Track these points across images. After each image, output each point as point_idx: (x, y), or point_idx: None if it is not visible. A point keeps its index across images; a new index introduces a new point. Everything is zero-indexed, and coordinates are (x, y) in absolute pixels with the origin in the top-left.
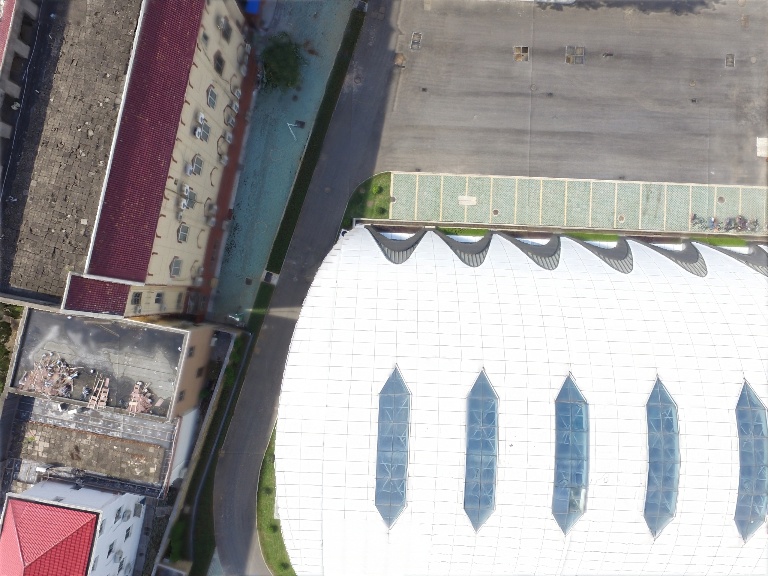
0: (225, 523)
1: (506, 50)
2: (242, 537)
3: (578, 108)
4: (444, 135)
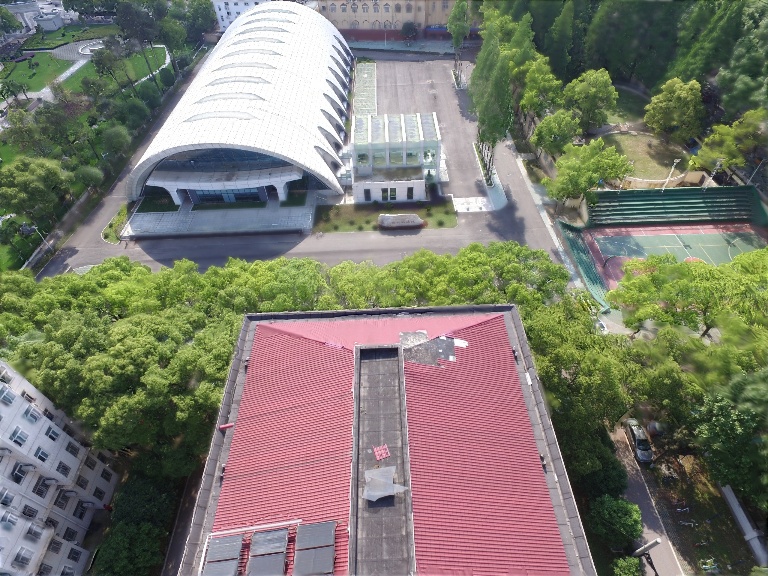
0: None
1: None
2: None
3: (409, 93)
4: (392, 70)
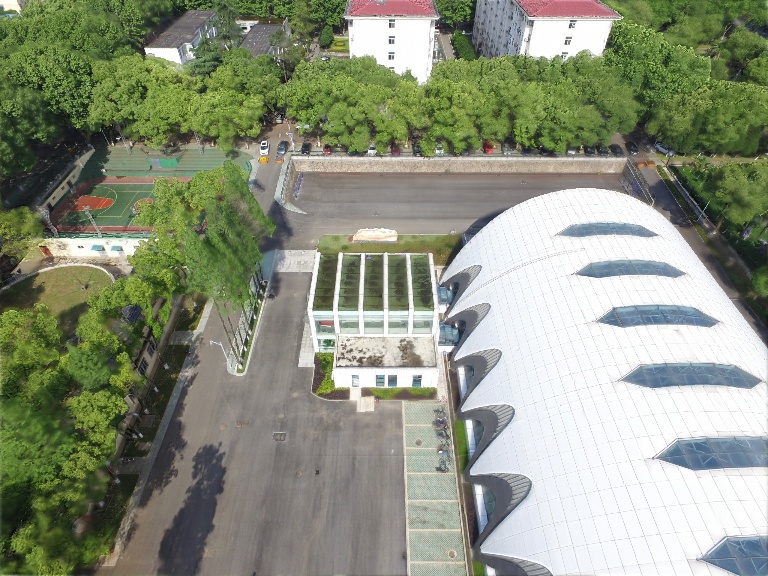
0: None
1: None
2: None
3: None
4: None
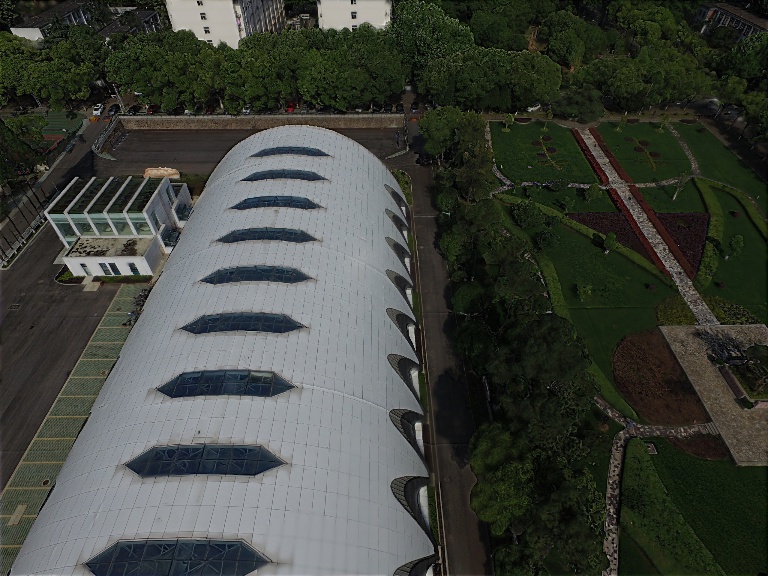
0: None
1: None
2: None
3: None
4: None
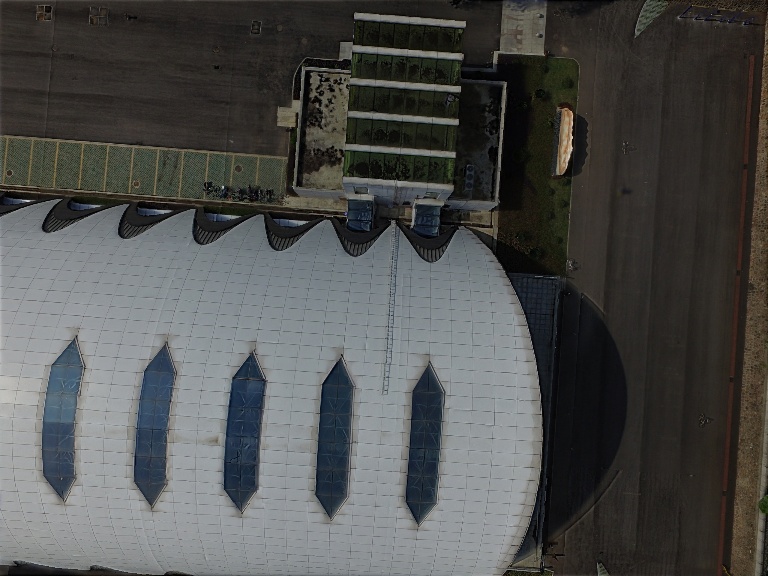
0: None
1: (29, 8)
2: None
3: (99, 70)
4: None
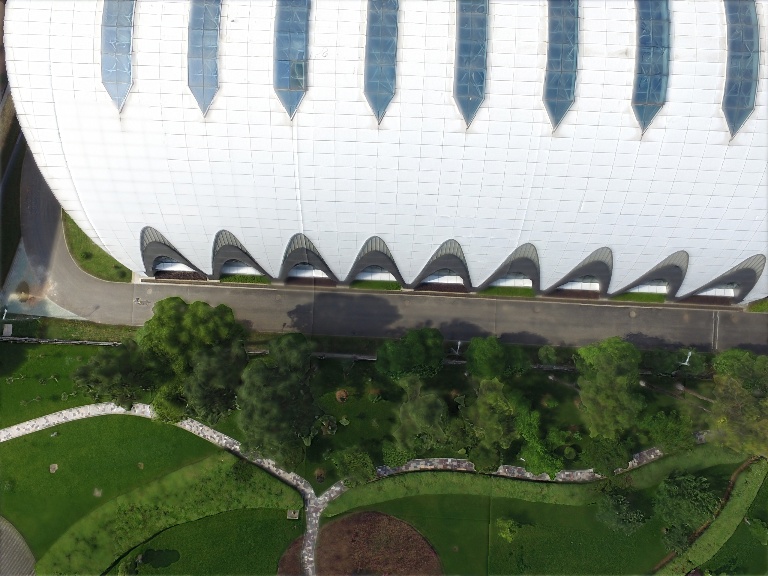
0: (31, 214)
1: None
2: (47, 227)
3: None
4: None
